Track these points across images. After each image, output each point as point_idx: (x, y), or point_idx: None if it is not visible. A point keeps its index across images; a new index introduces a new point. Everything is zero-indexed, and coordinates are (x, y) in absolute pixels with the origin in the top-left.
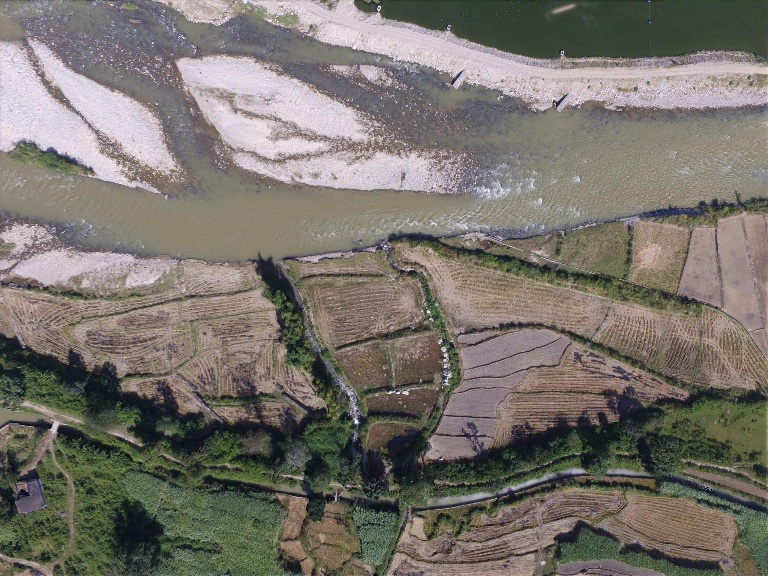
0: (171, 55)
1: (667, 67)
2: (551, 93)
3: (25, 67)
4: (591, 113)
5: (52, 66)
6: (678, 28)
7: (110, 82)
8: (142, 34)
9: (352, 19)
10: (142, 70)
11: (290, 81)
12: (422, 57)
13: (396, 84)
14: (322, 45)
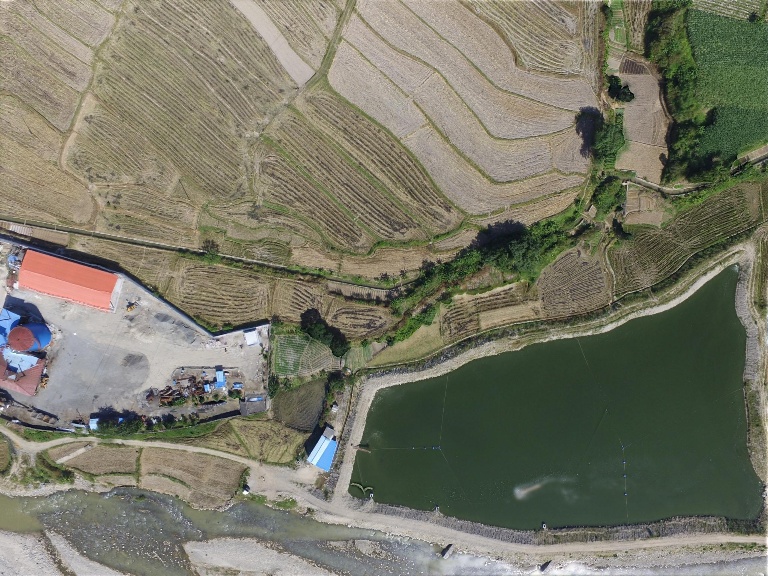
0: (178, 539)
1: (644, 539)
2: (535, 561)
3: (43, 557)
4: (574, 573)
5: (68, 556)
6: (653, 498)
7: (122, 566)
8: (151, 522)
9: (347, 509)
10: (152, 554)
11: (290, 557)
12: (413, 535)
13: (389, 556)
14: (319, 523)
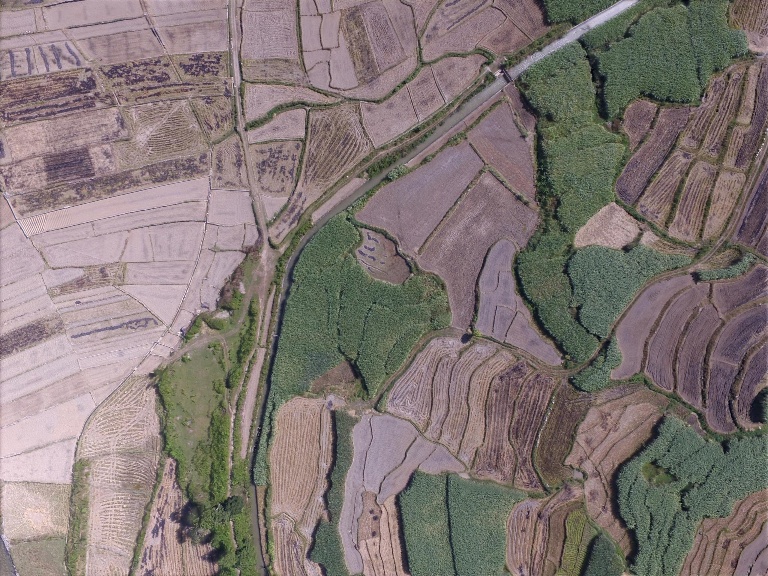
0: None
1: None
2: None
3: None
4: None
5: None
6: None
7: None
8: None
9: None
10: None
11: None
12: None
13: None
14: None
